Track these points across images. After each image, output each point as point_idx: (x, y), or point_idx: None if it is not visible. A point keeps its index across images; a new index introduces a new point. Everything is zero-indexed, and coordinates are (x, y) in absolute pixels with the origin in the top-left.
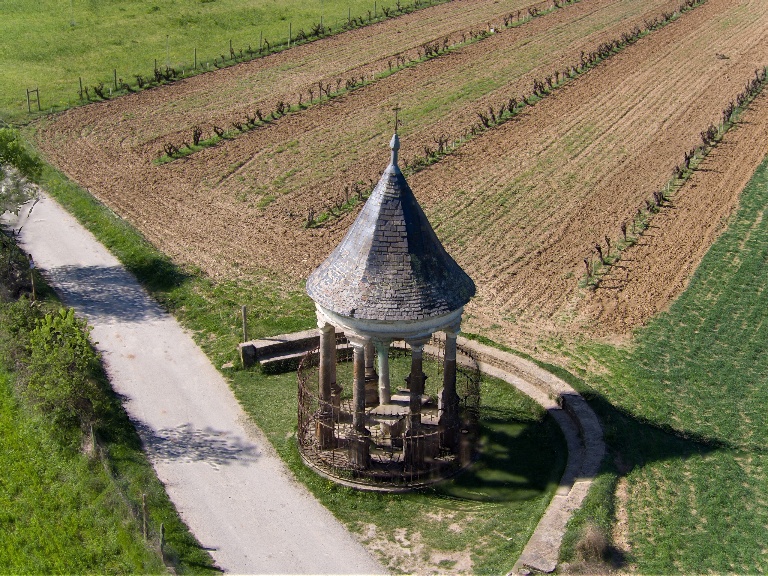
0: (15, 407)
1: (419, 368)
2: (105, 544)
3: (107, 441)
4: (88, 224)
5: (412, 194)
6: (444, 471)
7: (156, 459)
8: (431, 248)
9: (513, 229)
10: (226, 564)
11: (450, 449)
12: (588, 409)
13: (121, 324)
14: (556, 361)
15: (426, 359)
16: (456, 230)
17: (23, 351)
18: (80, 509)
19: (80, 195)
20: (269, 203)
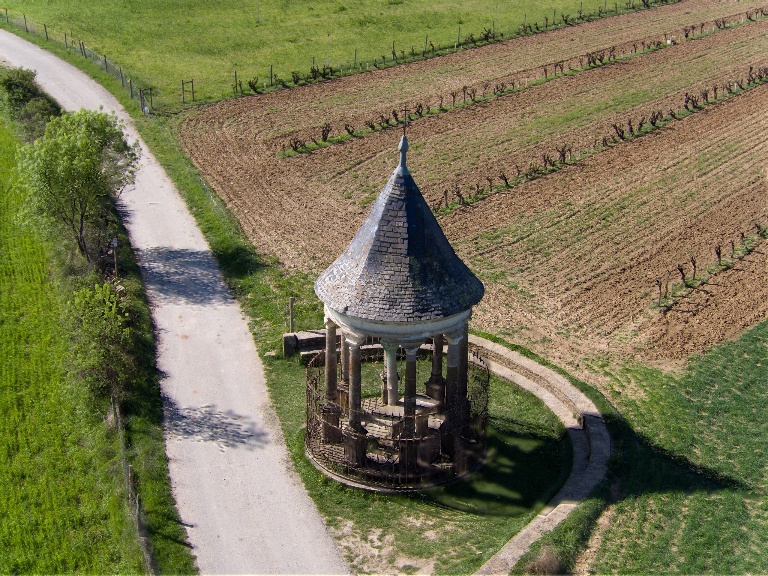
0: (65, 373)
1: (412, 371)
2: (96, 508)
3: (131, 413)
4: (194, 210)
5: (420, 197)
6: (438, 478)
7: (170, 435)
8: (434, 252)
9: (606, 244)
10: (197, 541)
11: (449, 456)
12: (604, 432)
13: (188, 306)
14: (593, 380)
15: None
16: (546, 240)
17: (80, 322)
18: (88, 473)
19: (196, 182)
20: (371, 201)
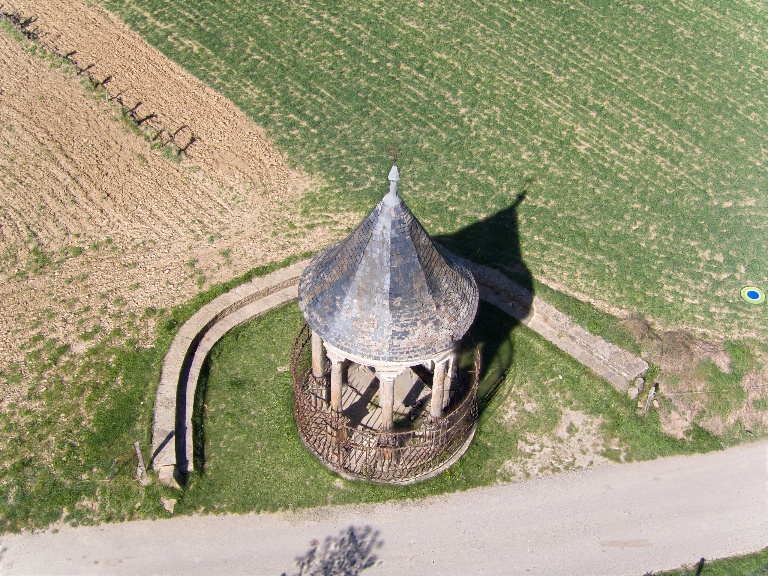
0: None
1: None
2: None
3: None
4: None
5: None
6: None
7: None
8: None
9: None
10: None
11: None
12: None
13: None
14: (323, 239)
15: (243, 329)
16: None
17: None
18: None
19: None
20: None
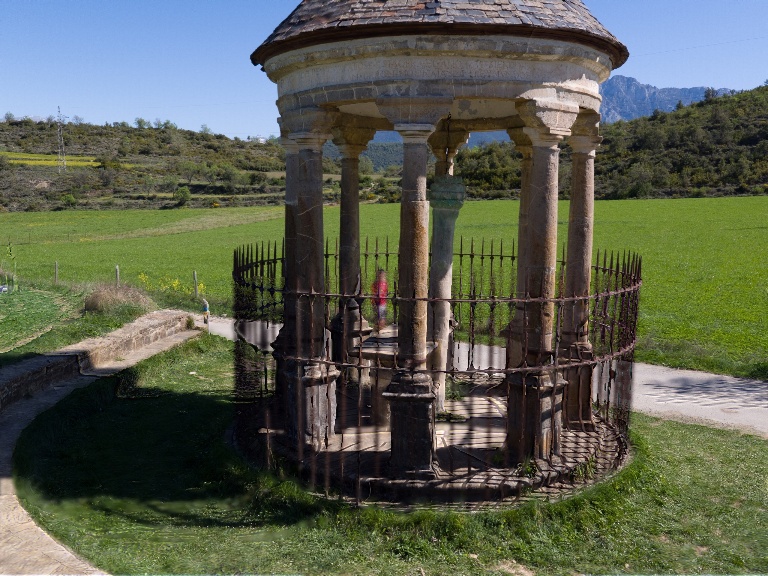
0: None
1: None
2: None
3: None
4: None
5: None
6: None
7: (745, 380)
8: None
9: None
10: None
11: None
12: None
13: None
14: None
15: None
16: None
17: None
18: None
19: None
20: None
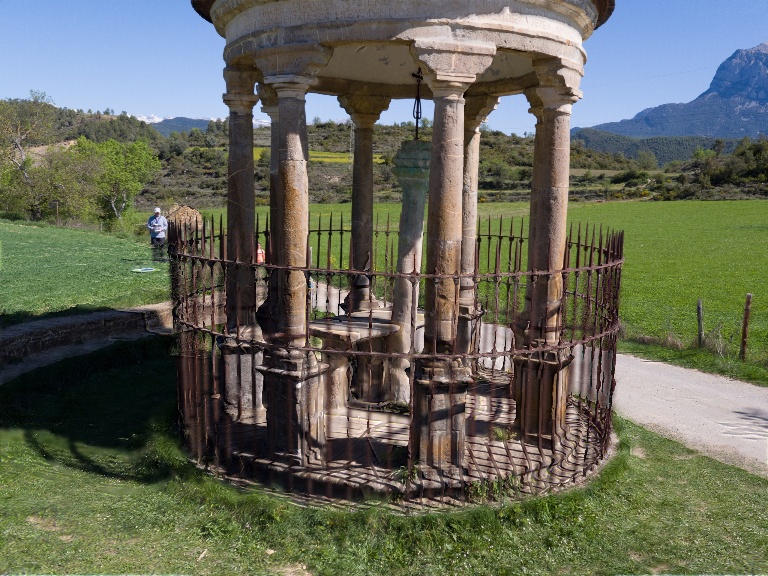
0: None
1: None
2: None
3: None
4: None
5: None
6: None
7: None
8: None
9: None
10: (619, 355)
11: None
12: None
13: None
14: None
15: None
16: None
17: None
18: None
19: None
20: None
